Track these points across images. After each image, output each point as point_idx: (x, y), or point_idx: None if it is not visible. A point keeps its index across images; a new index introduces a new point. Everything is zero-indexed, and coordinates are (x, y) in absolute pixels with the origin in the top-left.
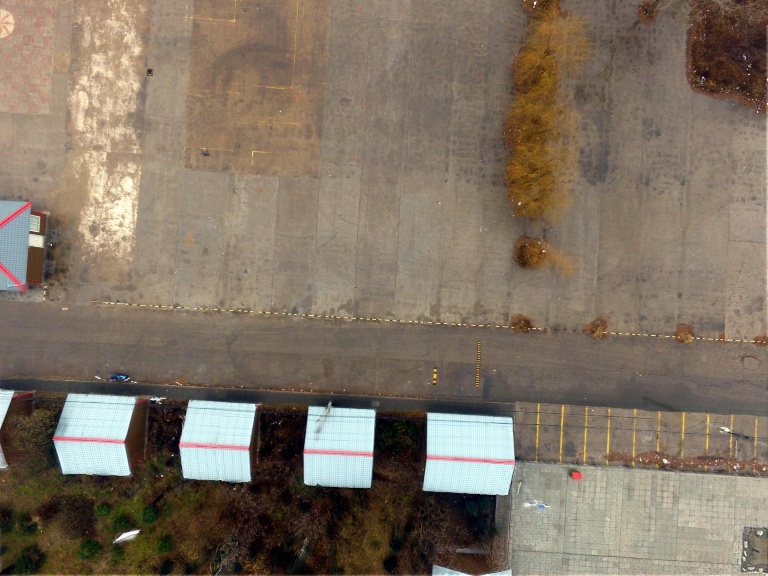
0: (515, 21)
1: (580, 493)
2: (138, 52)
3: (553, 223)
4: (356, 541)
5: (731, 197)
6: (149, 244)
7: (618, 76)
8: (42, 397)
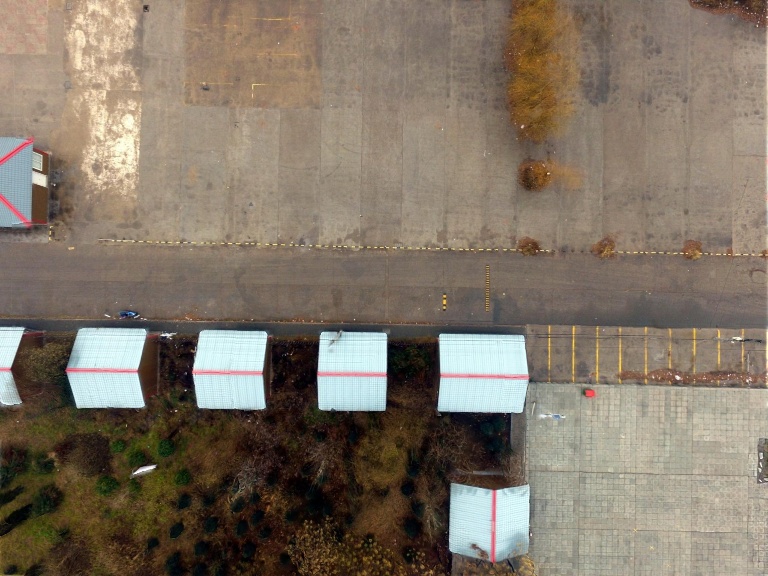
0: None
1: (594, 412)
2: None
3: (557, 145)
4: (374, 457)
5: (734, 112)
6: (153, 180)
7: None
8: (53, 335)
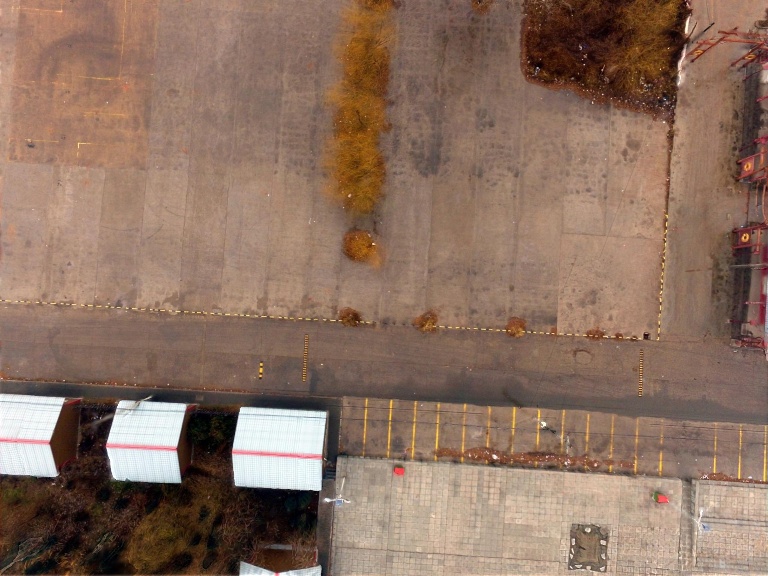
0: (347, 11)
1: (405, 489)
2: None
3: (384, 215)
4: (147, 536)
5: (565, 189)
6: None
7: (451, 67)
8: None
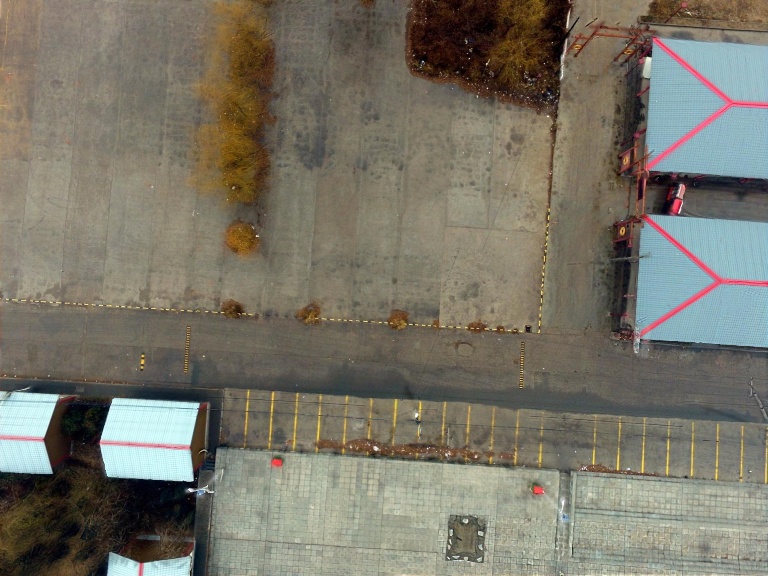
0: (233, 3)
1: (284, 480)
2: None
3: (268, 208)
4: (5, 526)
5: (449, 182)
6: None
7: (336, 59)
8: None
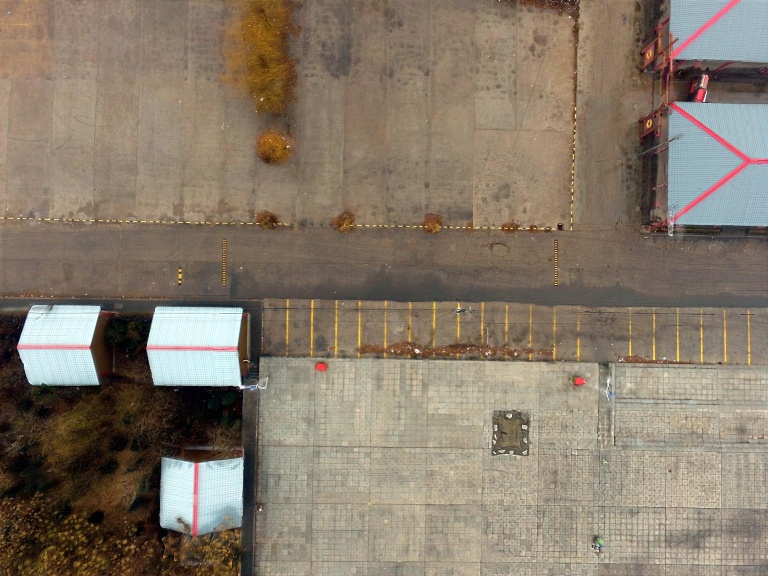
0: None
1: (329, 385)
2: None
3: (297, 118)
4: (59, 429)
5: (476, 86)
6: None
7: None
8: None
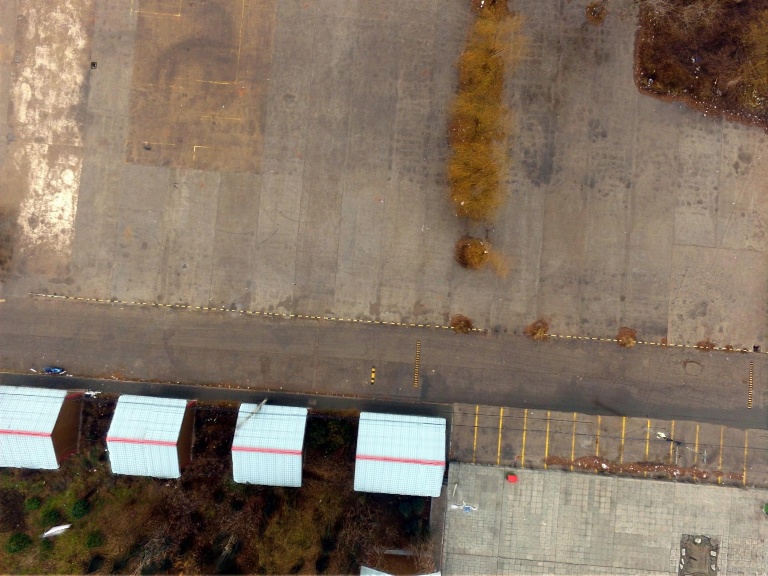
0: (462, 20)
1: (516, 496)
2: (82, 45)
3: (496, 223)
4: (278, 540)
5: (677, 200)
6: (88, 237)
7: (564, 77)
8: None
